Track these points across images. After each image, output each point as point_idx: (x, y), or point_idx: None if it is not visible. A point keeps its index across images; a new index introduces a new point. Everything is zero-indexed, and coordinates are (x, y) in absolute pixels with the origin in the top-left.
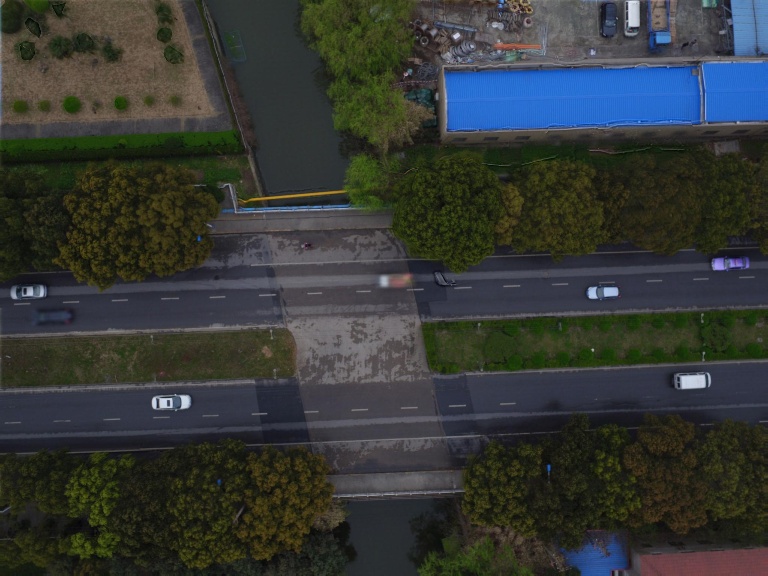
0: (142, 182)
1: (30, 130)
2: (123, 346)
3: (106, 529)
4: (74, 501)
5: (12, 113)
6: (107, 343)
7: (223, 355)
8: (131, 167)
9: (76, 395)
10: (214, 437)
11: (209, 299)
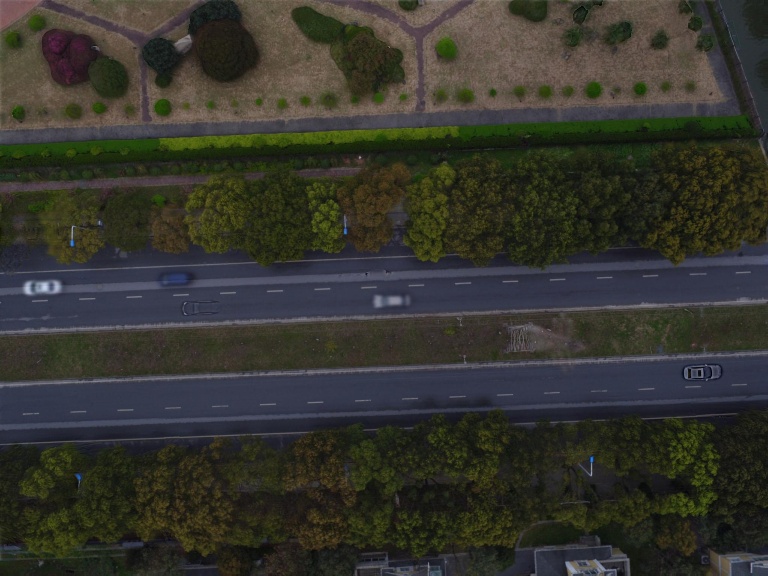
0: (735, 161)
1: (551, 114)
2: (656, 319)
3: (705, 489)
4: (675, 463)
5: (534, 98)
6: (641, 316)
7: (751, 327)
8: (652, 149)
9: (612, 366)
10: (762, 404)
11: (736, 274)
